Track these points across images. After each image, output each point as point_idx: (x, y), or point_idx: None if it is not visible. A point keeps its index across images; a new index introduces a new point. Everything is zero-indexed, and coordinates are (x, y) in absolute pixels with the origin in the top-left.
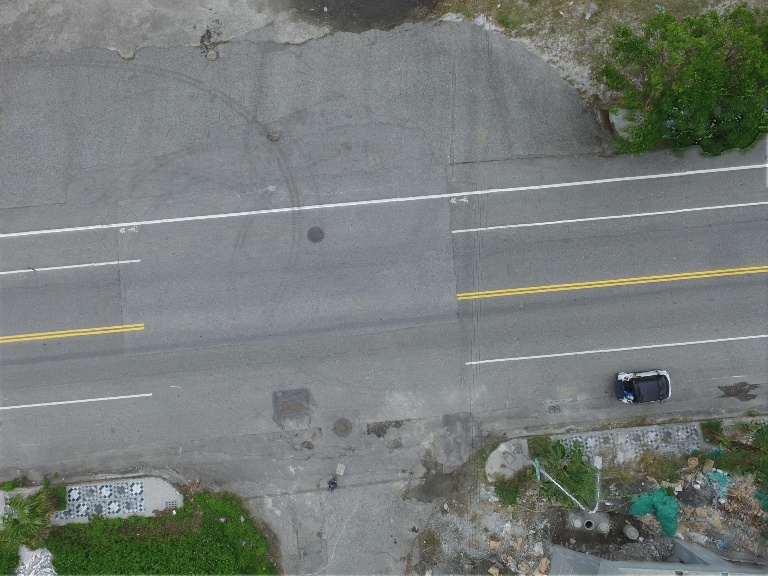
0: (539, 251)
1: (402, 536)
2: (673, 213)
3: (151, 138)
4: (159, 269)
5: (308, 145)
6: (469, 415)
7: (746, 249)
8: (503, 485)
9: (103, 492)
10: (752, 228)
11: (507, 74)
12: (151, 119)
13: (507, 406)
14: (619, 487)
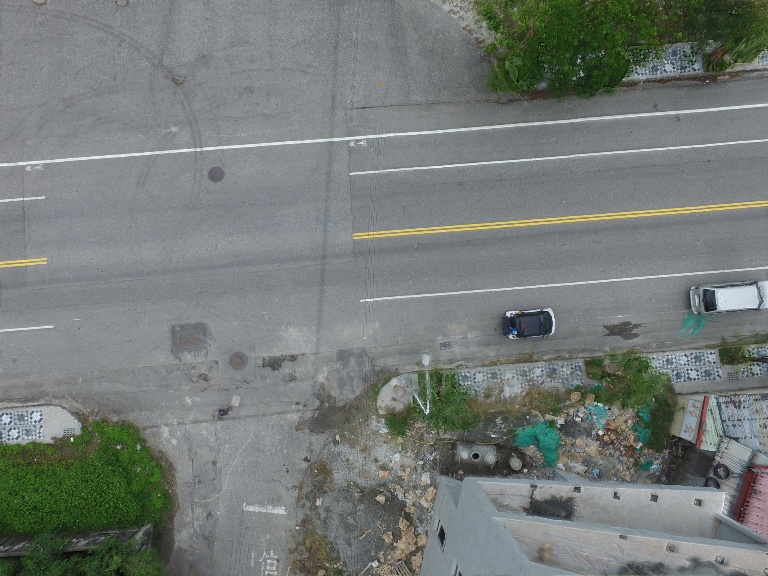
0: (433, 193)
1: (294, 465)
2: (564, 158)
3: (59, 80)
4: (63, 206)
5: (212, 89)
6: (362, 350)
7: (633, 193)
8: (392, 417)
9: (3, 419)
10: (639, 173)
11: (409, 23)
12: (60, 62)
13: (399, 342)
14: (505, 420)
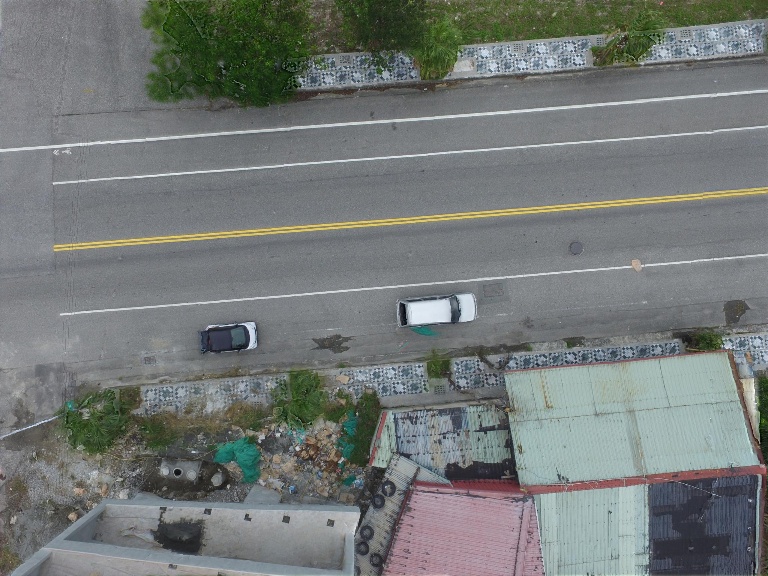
0: (138, 204)
1: None
2: (276, 168)
3: None
4: None
5: None
6: (62, 365)
7: (345, 204)
8: None
9: None
10: (352, 184)
11: (123, 26)
12: None
13: (102, 357)
14: (207, 436)
